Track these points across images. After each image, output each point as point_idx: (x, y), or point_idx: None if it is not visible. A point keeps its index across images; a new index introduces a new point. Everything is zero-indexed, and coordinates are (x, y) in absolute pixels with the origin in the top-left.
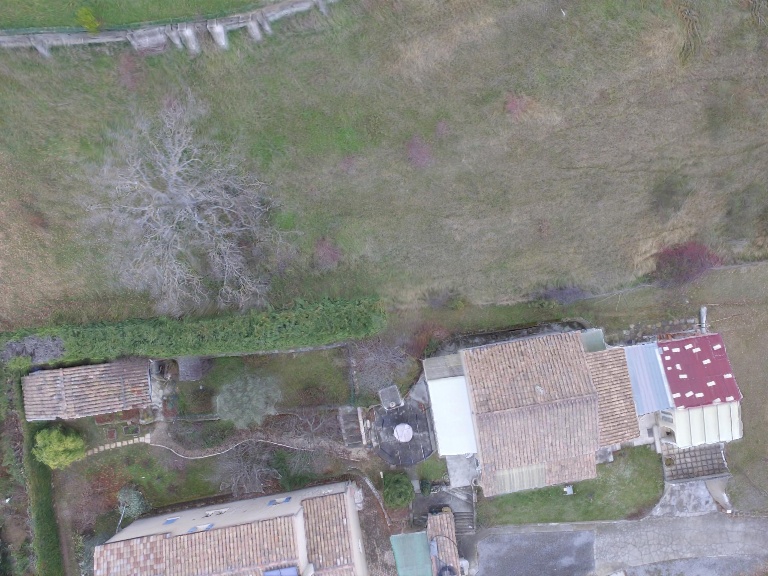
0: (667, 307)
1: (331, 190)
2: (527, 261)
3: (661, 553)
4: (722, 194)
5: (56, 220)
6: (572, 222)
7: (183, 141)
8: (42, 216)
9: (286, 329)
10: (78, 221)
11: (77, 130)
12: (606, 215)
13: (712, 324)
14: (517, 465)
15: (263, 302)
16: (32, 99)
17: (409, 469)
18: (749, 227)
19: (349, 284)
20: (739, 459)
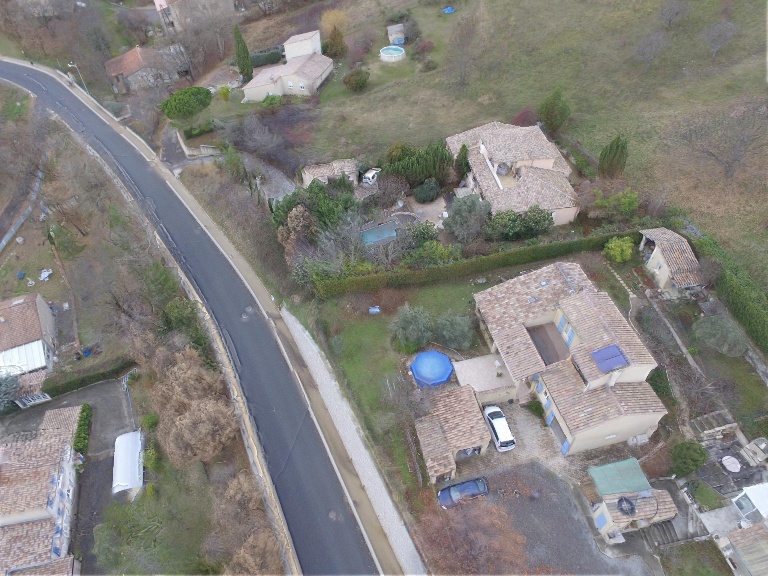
0: None
1: None
2: None
3: None
4: None
5: None
6: None
7: None
8: None
9: None
10: None
11: None
12: None
13: None
14: None
15: None
16: None
17: (695, 475)
18: None
19: None
20: None
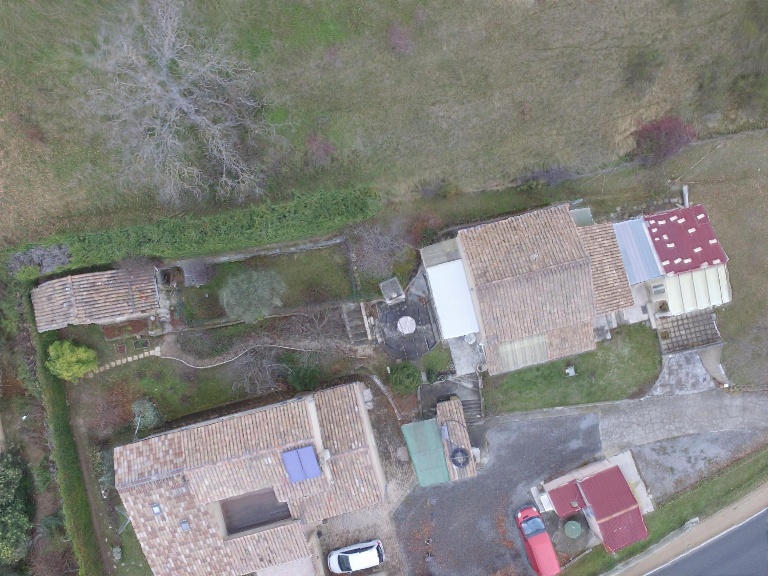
0: (650, 187)
1: (320, 85)
2: (513, 145)
3: (664, 431)
4: (693, 67)
5: (55, 134)
6: (553, 103)
7: (175, 26)
8: (41, 130)
9: (286, 219)
10: (77, 134)
11: (71, 39)
12: (585, 94)
13: (695, 201)
14: (518, 336)
15: (262, 196)
16: (25, 9)
17: (415, 362)
18: (721, 100)
19: (344, 181)
20: (731, 329)
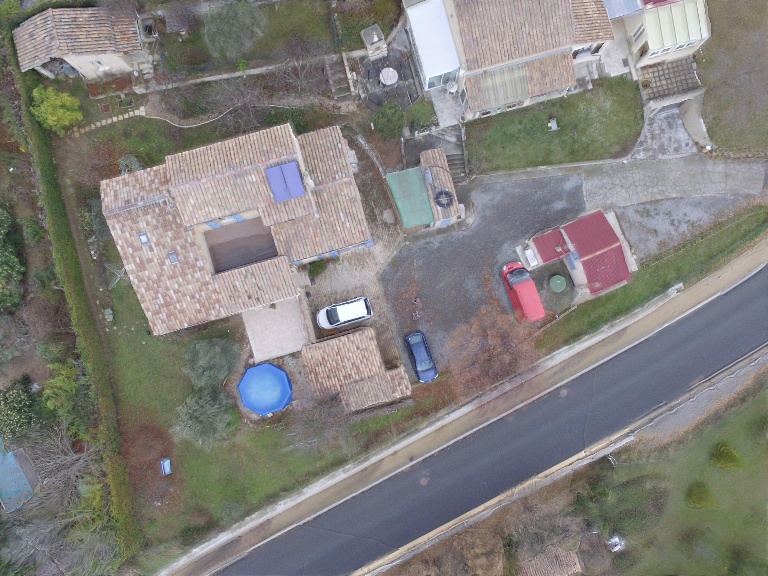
0: None
1: None
2: None
3: (648, 193)
4: None
5: None
6: None
7: None
8: None
9: None
10: None
11: None
12: None
13: None
14: (498, 61)
15: None
16: None
17: None
18: None
19: None
20: (712, 80)
